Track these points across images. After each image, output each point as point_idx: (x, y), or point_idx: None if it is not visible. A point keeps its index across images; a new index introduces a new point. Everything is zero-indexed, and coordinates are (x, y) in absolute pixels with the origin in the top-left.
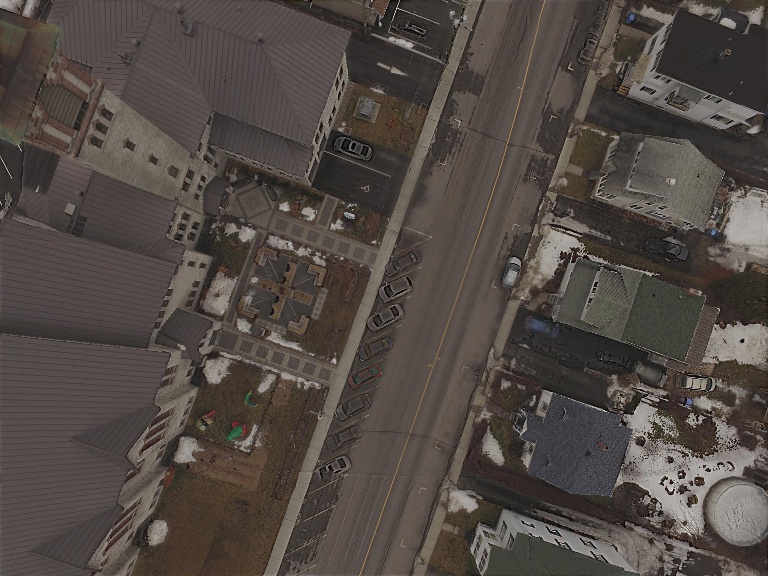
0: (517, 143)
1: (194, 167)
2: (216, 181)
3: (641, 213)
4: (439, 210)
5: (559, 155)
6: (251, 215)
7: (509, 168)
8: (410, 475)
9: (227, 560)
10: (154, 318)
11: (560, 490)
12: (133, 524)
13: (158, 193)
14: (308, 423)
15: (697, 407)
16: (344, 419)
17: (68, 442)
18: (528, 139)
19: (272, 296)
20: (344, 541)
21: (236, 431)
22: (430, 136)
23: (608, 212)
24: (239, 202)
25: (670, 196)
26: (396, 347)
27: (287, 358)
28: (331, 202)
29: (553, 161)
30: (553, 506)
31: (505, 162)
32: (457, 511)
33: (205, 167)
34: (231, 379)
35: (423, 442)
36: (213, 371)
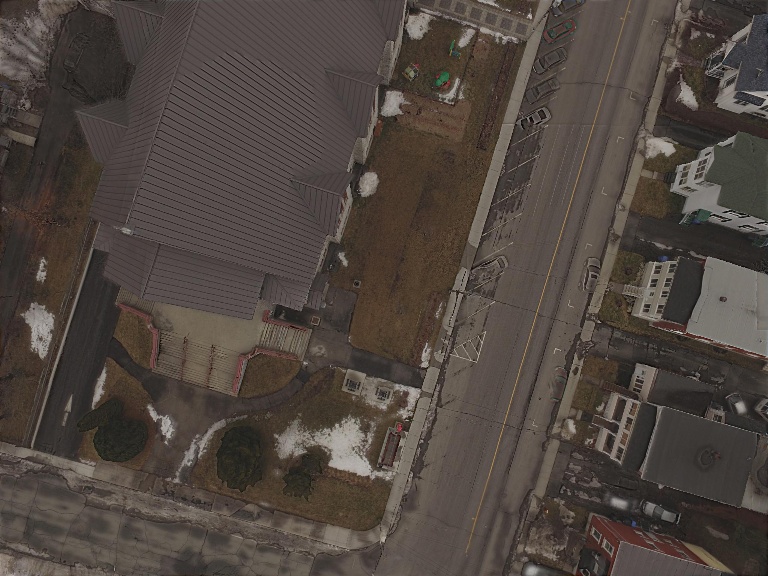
0: None
1: None
2: None
3: None
4: None
5: None
6: None
7: None
8: (608, 124)
9: (437, 209)
10: None
11: None
12: (366, 140)
13: None
14: (508, 76)
15: None
16: (542, 72)
17: None
18: None
19: None
20: (548, 189)
21: (446, 74)
22: None
23: None
24: None
25: None
26: (588, 2)
27: (485, 14)
28: None
29: None
30: None
31: None
32: (655, 156)
33: None
34: (432, 35)
35: (618, 93)
36: (415, 26)
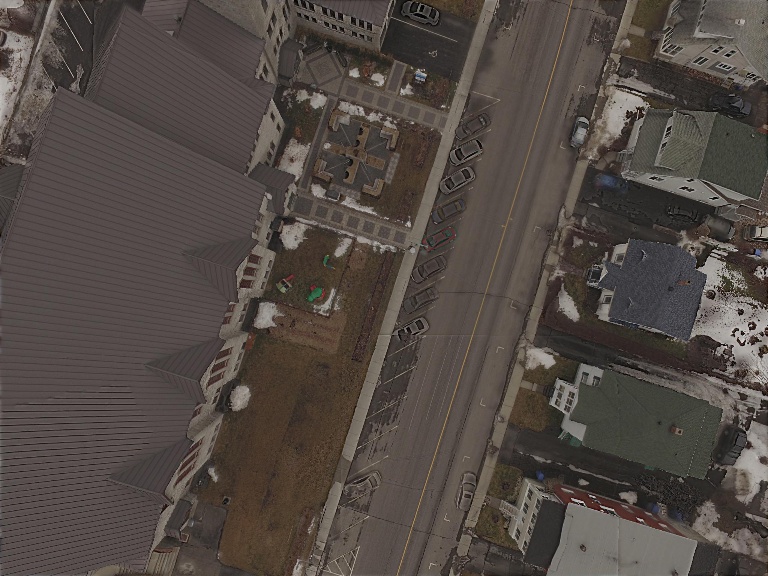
0: (580, 6)
1: (277, 12)
2: (290, 42)
3: (704, 70)
4: (506, 73)
5: (621, 17)
6: (322, 82)
7: (573, 31)
8: (487, 335)
9: (310, 423)
10: (248, 153)
11: (636, 342)
12: (224, 375)
13: (253, 20)
14: (385, 286)
15: (764, 259)
16: (420, 281)
17: (180, 255)
18: (590, 2)
19: (345, 161)
20: (425, 401)
21: (317, 291)
22: (494, 1)
23: (671, 71)
24: (309, 69)
25: (740, 37)
26: (469, 209)
27: (362, 222)
28: (400, 68)
29: (615, 23)
30: (628, 360)
31: (569, 25)
32: (535, 368)
33: (283, 20)
34: (308, 244)
35: (499, 302)
36: (290, 236)
